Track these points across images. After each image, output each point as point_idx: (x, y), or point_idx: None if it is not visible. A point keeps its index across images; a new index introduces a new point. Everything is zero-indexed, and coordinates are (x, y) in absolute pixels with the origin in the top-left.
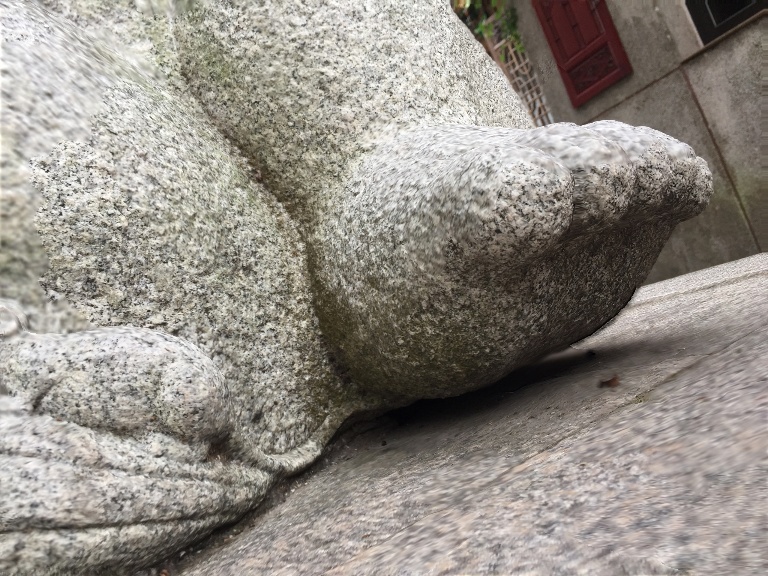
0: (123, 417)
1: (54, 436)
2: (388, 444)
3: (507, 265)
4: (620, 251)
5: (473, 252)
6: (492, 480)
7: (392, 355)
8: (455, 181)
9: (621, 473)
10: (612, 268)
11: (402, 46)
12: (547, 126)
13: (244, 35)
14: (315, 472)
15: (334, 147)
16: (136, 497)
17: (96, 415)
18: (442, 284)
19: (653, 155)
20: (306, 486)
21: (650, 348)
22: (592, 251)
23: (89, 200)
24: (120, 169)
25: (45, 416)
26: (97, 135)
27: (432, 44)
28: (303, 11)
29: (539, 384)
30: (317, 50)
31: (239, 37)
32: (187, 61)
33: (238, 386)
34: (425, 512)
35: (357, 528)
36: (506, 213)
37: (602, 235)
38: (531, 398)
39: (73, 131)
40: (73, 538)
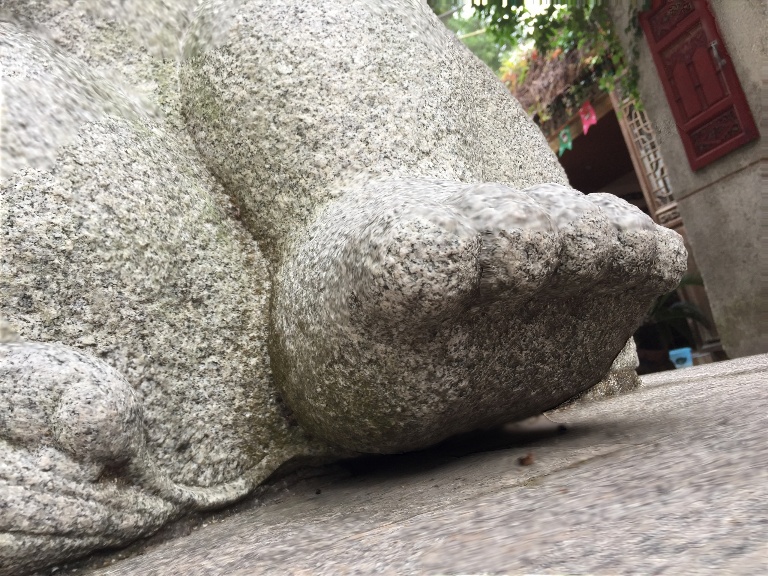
0: (19, 428)
1: None
2: (322, 493)
3: (405, 323)
4: (566, 322)
5: (369, 306)
6: None
7: (314, 402)
8: (359, 233)
9: (402, 557)
10: (556, 339)
11: (387, 98)
12: (476, 185)
13: (235, 80)
14: (239, 510)
15: (305, 191)
16: (9, 506)
17: None
18: (349, 336)
19: (586, 223)
20: (221, 523)
21: (609, 430)
22: (526, 318)
23: (38, 223)
24: (77, 197)
25: None
26: (61, 164)
27: (423, 97)
28: (290, 60)
29: (484, 453)
30: (299, 98)
31: (230, 82)
32: (187, 102)
33: (165, 414)
34: (248, 566)
35: (188, 571)
36: (393, 270)
37: (538, 303)
38: (459, 466)
39: (37, 159)
40: None
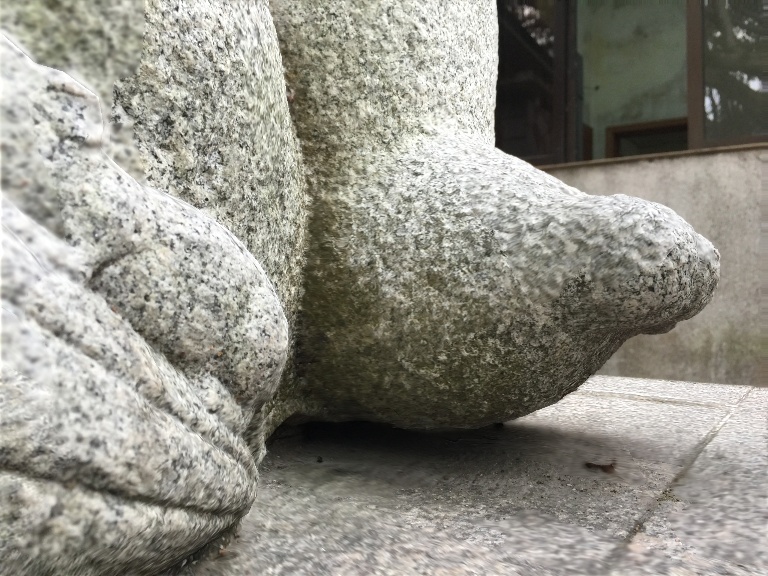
0: (190, 338)
1: (118, 334)
2: (325, 462)
3: (618, 323)
4: (621, 342)
5: (605, 298)
6: (610, 555)
7: (416, 367)
8: (616, 218)
9: None
10: None
11: (480, 48)
12: None
13: None
14: None
15: (394, 111)
16: (193, 467)
17: (162, 322)
18: (537, 315)
19: None
20: None
21: (577, 438)
22: (621, 334)
23: (208, 13)
24: None
25: (99, 296)
26: None
27: (492, 62)
28: None
29: (485, 442)
30: (420, 1)
31: None
32: None
33: None
34: None
35: None
36: (669, 274)
37: None
38: (501, 457)
39: None
40: (120, 513)
